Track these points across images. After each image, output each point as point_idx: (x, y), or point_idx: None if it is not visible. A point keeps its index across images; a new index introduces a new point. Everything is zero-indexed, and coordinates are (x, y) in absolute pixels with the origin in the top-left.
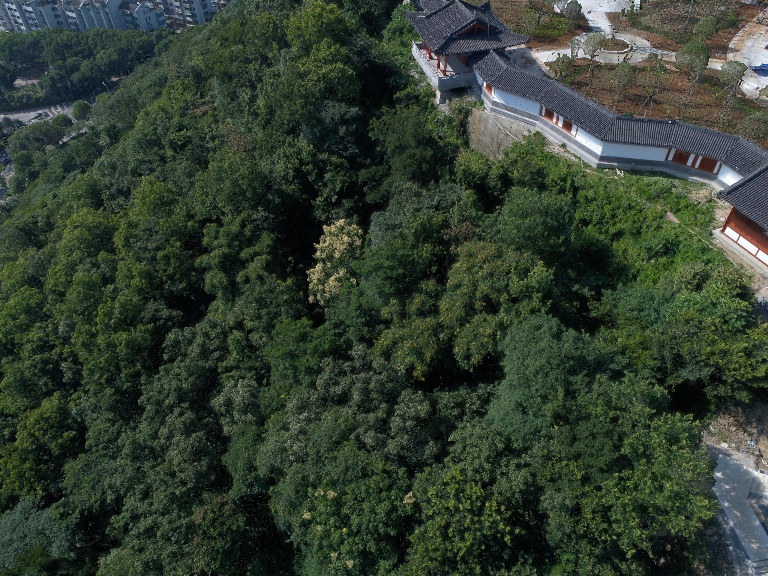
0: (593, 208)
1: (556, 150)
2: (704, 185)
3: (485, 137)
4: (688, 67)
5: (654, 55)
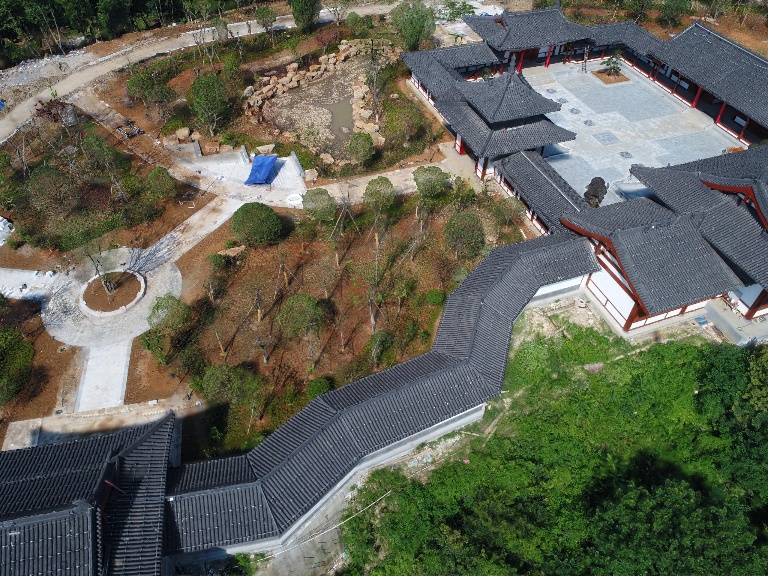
0: (569, 449)
1: (424, 460)
2: (523, 314)
3: (296, 572)
4: (271, 236)
5: (219, 257)
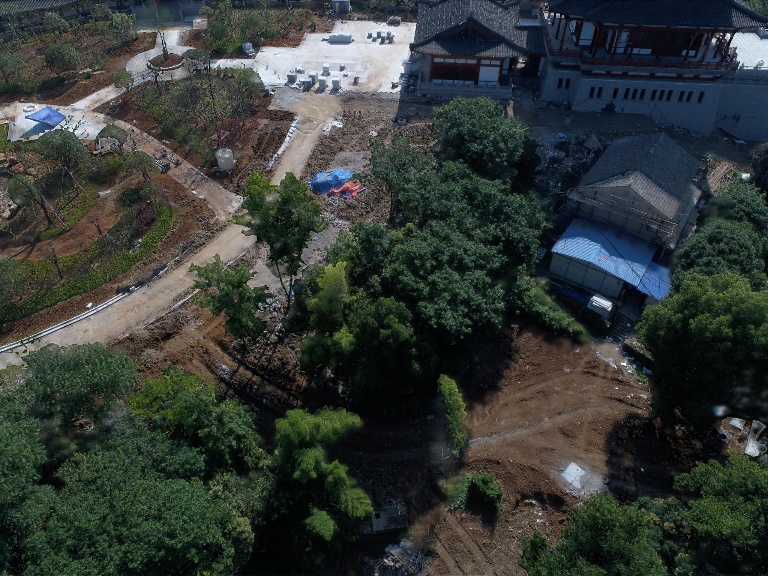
0: None
1: None
2: None
3: None
4: None
5: None
